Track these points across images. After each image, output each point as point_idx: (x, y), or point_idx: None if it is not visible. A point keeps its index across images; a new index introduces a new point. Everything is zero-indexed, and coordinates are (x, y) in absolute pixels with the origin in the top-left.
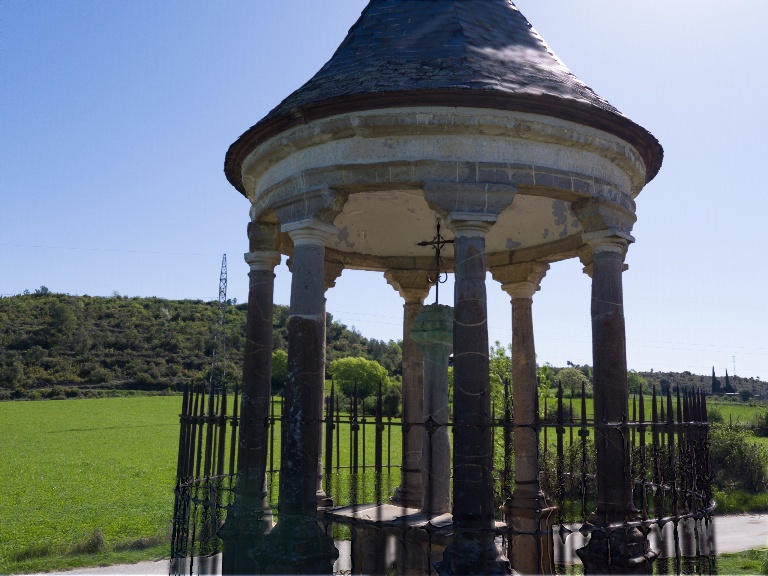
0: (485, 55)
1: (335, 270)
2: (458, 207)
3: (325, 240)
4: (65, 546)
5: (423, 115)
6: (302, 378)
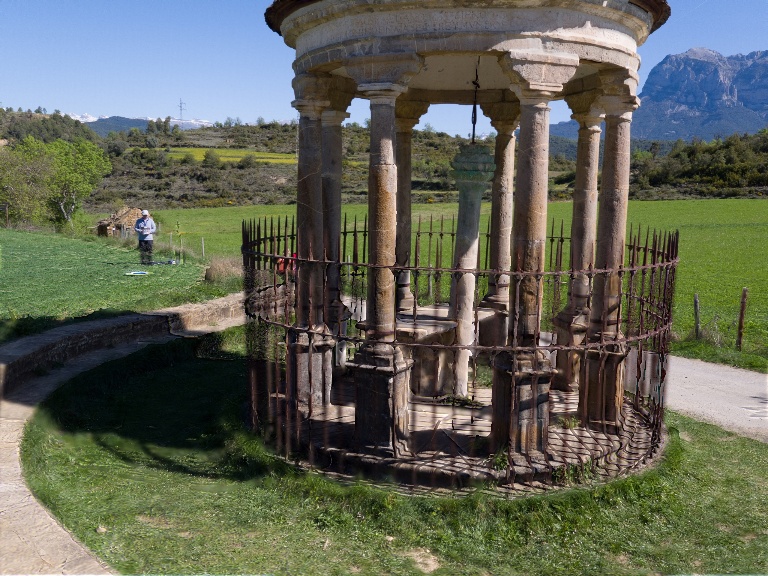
0: None
1: (517, 108)
2: None
3: (332, 121)
4: None
5: None
6: None
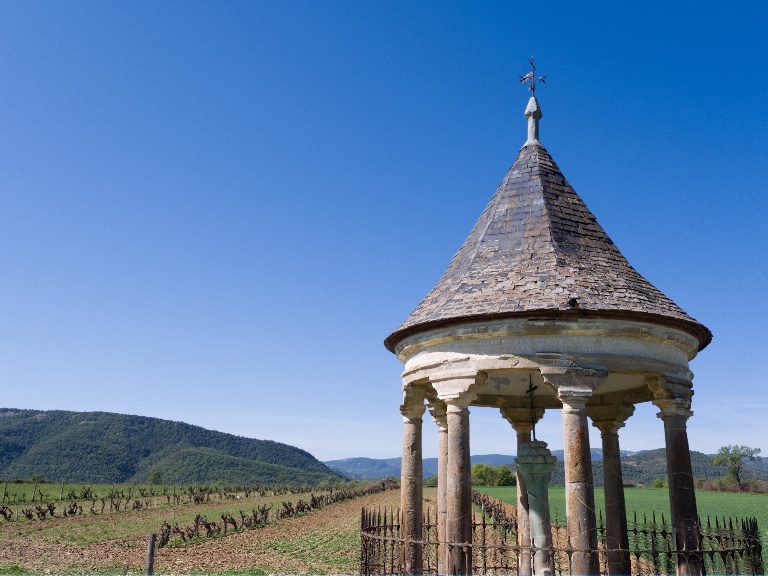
0: None
1: None
2: None
3: None
4: None
5: None
6: None
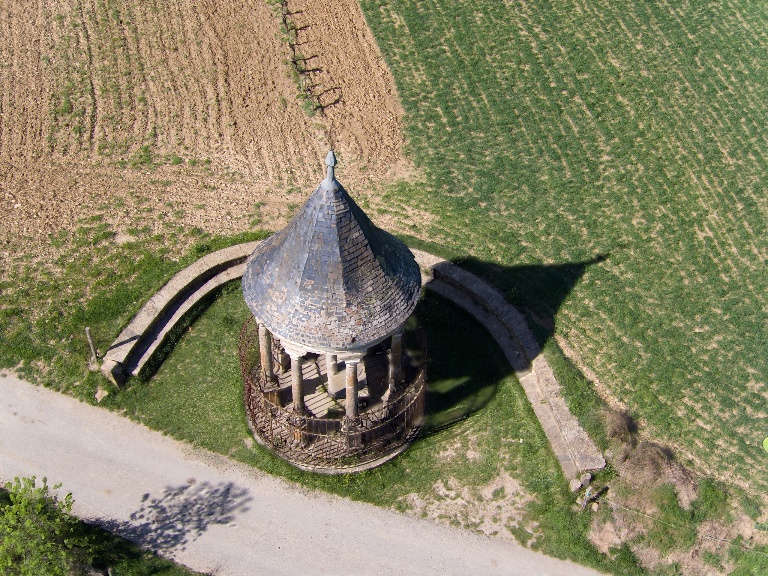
0: None
1: None
2: None
3: None
4: None
5: None
6: None
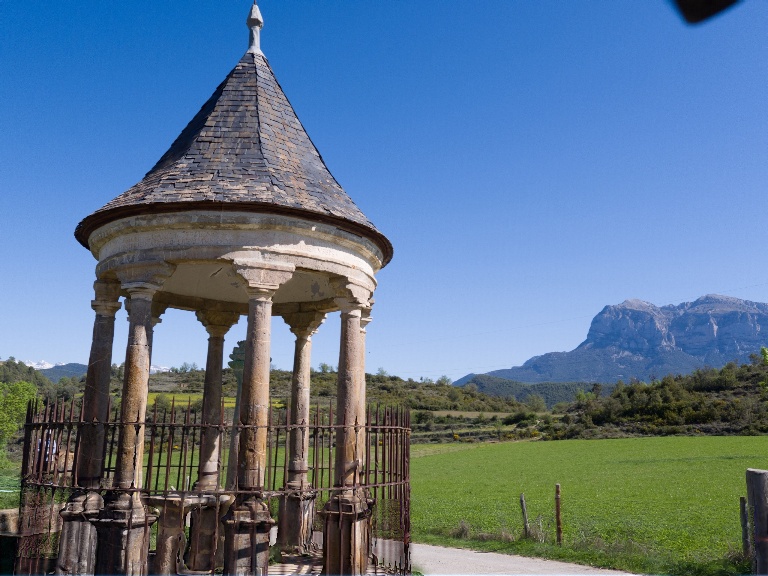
0: None
1: (310, 317)
2: None
3: None
4: (450, 530)
5: None
6: None
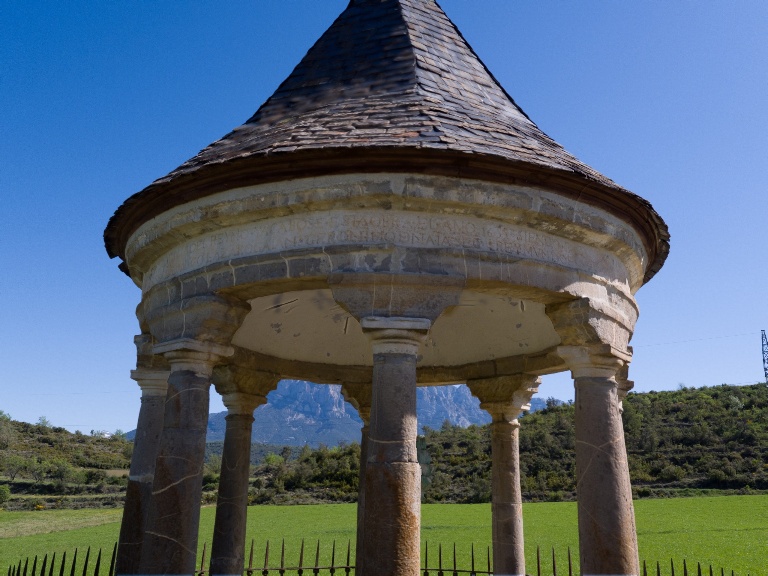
0: (240, 132)
1: None
2: (164, 337)
3: (166, 388)
4: None
5: (140, 237)
6: (121, 549)
